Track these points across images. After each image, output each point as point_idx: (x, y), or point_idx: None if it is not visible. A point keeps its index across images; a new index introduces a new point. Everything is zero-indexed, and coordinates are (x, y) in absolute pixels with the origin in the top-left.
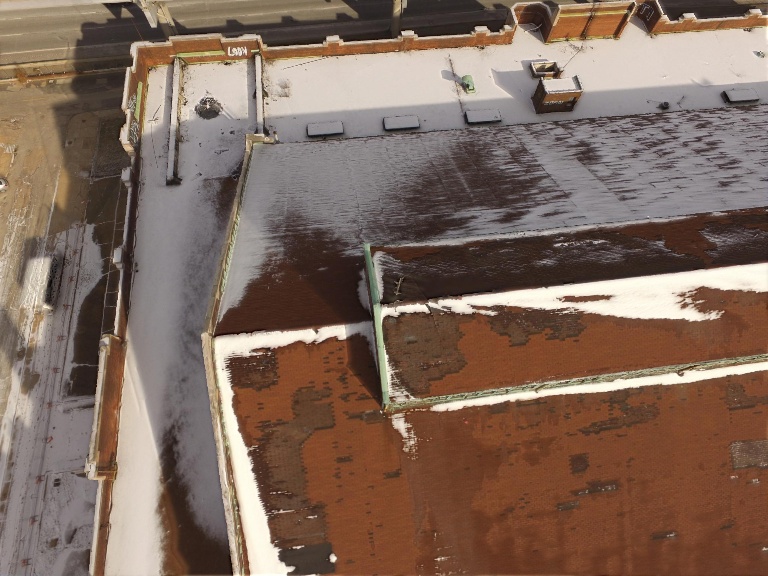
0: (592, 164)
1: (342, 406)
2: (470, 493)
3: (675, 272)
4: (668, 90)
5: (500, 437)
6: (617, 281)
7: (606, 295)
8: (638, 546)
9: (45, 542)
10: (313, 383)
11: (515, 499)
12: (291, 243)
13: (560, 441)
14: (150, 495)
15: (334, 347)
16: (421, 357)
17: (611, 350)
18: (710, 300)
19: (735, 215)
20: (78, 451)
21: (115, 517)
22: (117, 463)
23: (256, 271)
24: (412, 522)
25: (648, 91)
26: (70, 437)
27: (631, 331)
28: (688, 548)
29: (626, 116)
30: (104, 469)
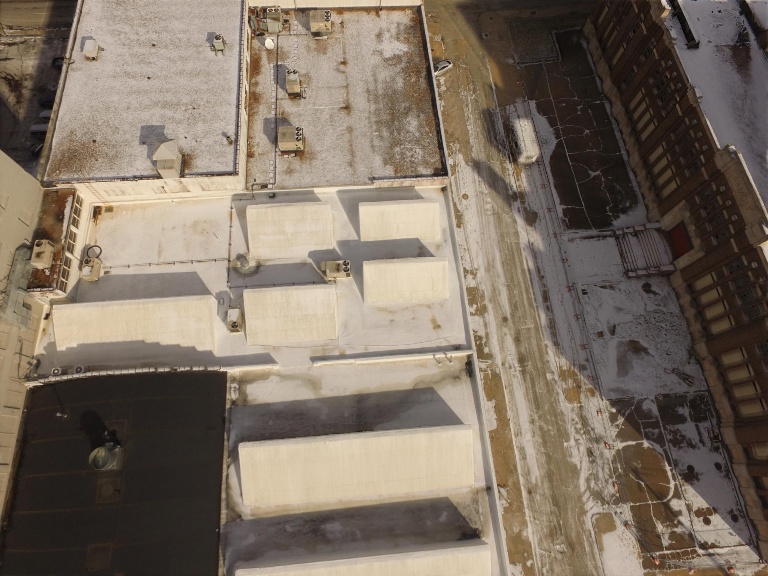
0: None
1: None
2: None
3: None
4: None
5: None
6: None
7: None
8: None
9: (593, 333)
10: None
11: None
12: None
13: None
14: None
15: None
16: None
17: None
18: None
19: None
20: (593, 270)
21: None
22: None
23: None
24: None
25: None
26: (582, 259)
27: None
28: None
29: None
30: None
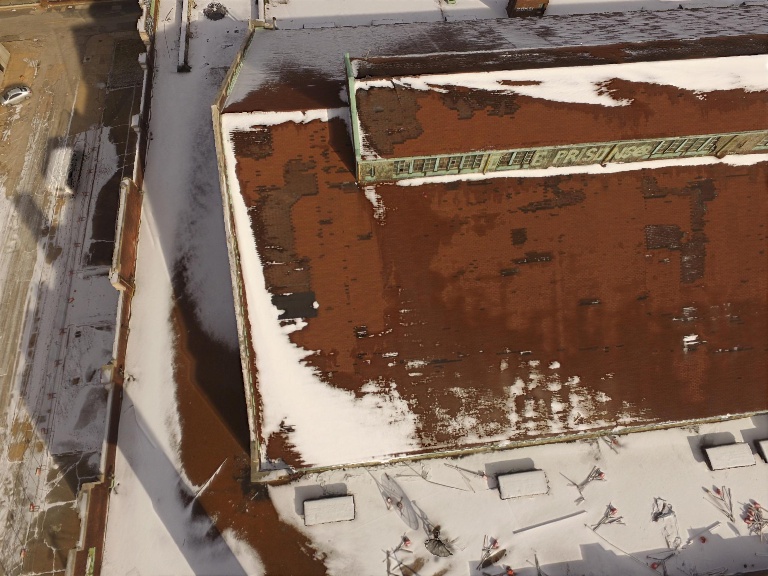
0: (549, 37)
1: (324, 177)
2: (428, 256)
3: (593, 65)
4: (630, 4)
5: (453, 210)
6: (546, 69)
7: (537, 81)
8: (568, 310)
9: (68, 380)
10: (301, 156)
11: (466, 264)
12: (286, 75)
13: (503, 217)
14: (163, 308)
15: (318, 127)
16: (387, 124)
17: (541, 127)
18: (622, 90)
19: (653, 42)
20: (97, 309)
21: (133, 324)
22: (135, 284)
23: (256, 87)
24: (381, 278)
25: (612, 5)
26: (89, 298)
27: (557, 112)
28: (610, 314)
29: (586, 14)
30: (125, 281)
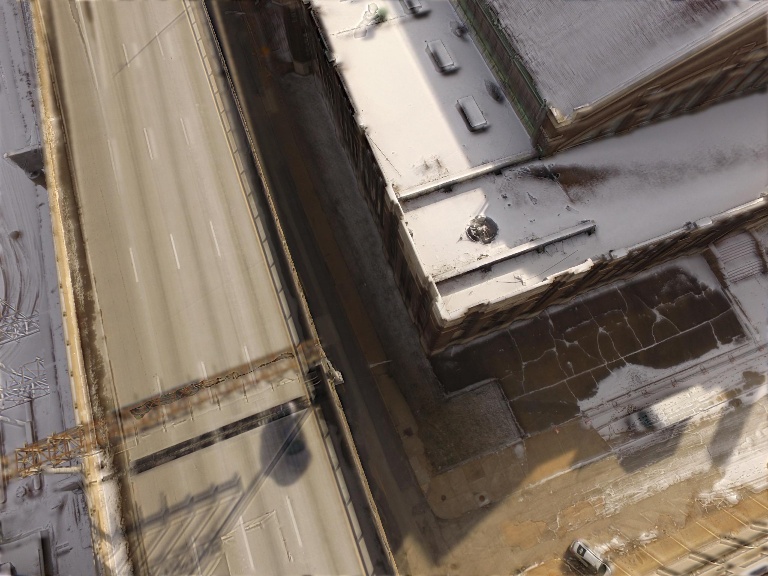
0: None
1: None
2: None
3: None
4: None
5: None
6: None
7: None
8: None
9: None
10: None
11: None
12: None
13: None
14: None
15: None
16: None
17: None
18: None
19: None
20: None
21: None
22: None
23: None
24: None
25: None
26: None
27: None
28: None
29: None
30: None
